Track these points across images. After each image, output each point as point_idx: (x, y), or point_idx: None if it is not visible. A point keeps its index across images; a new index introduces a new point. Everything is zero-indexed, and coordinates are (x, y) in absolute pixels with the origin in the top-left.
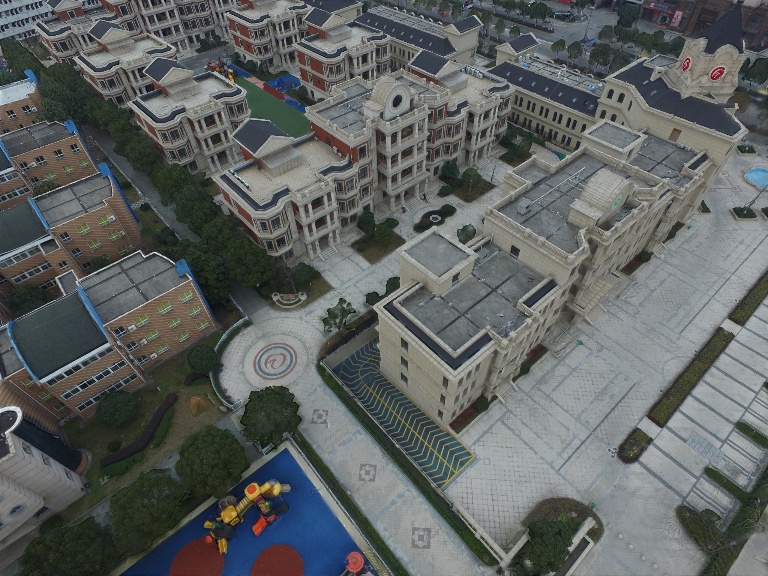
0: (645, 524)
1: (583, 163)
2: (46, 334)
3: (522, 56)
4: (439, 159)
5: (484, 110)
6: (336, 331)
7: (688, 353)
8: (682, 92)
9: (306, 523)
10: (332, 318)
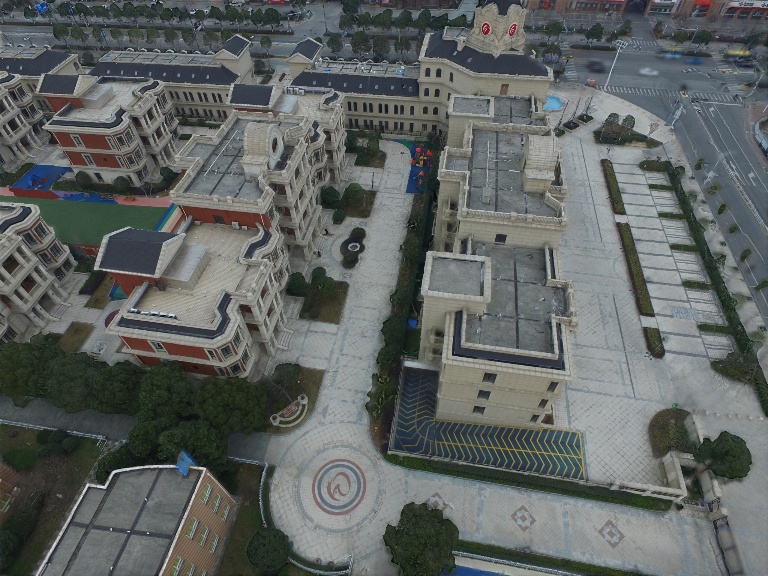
0: (708, 392)
1: (481, 138)
2: None
3: (316, 62)
4: (316, 188)
5: (336, 124)
6: None
7: (618, 253)
8: (493, 53)
9: None
10: None
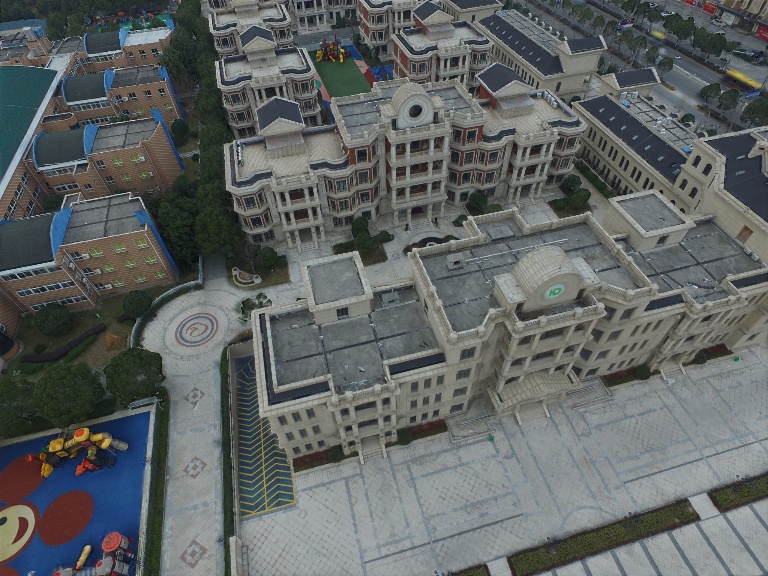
0: None
1: (573, 233)
2: (14, 238)
3: (627, 92)
4: (468, 185)
5: (530, 143)
6: None
7: (618, 511)
8: None
9: (117, 485)
10: (247, 309)
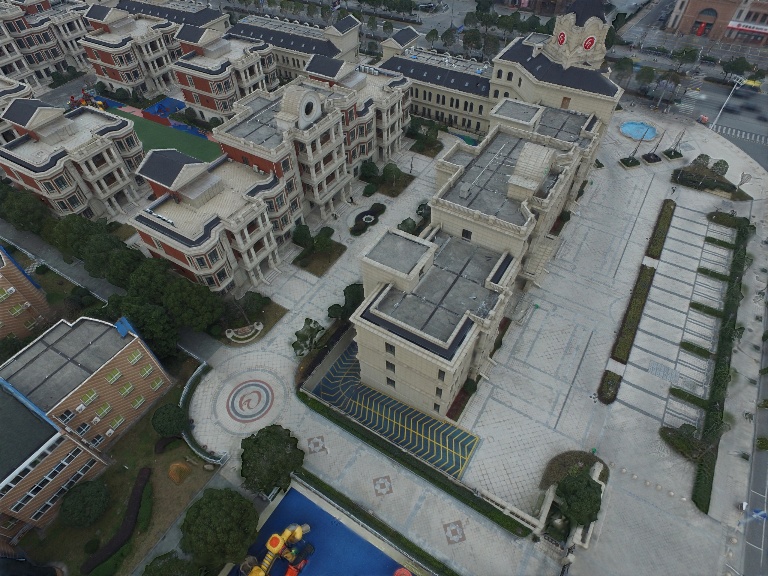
0: (639, 453)
1: (501, 141)
2: None
3: (408, 49)
4: (357, 160)
5: (390, 105)
6: (305, 353)
7: (625, 293)
8: (563, 64)
9: (337, 557)
10: (302, 341)
